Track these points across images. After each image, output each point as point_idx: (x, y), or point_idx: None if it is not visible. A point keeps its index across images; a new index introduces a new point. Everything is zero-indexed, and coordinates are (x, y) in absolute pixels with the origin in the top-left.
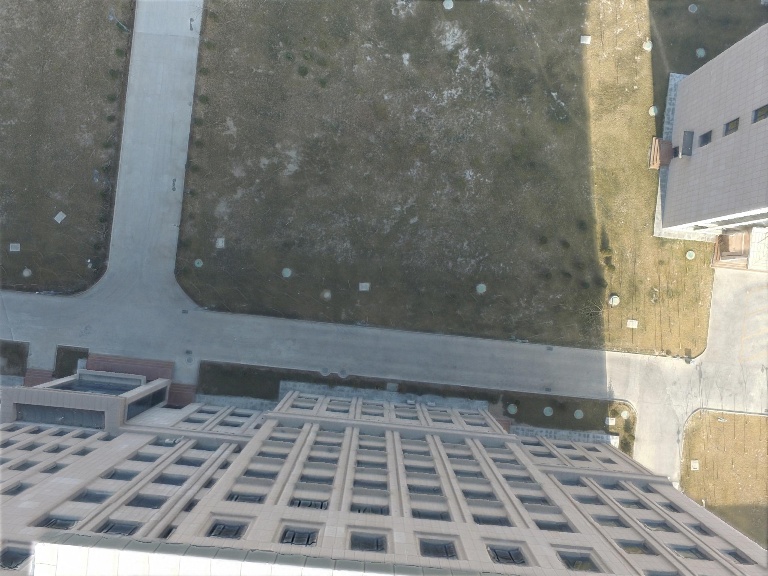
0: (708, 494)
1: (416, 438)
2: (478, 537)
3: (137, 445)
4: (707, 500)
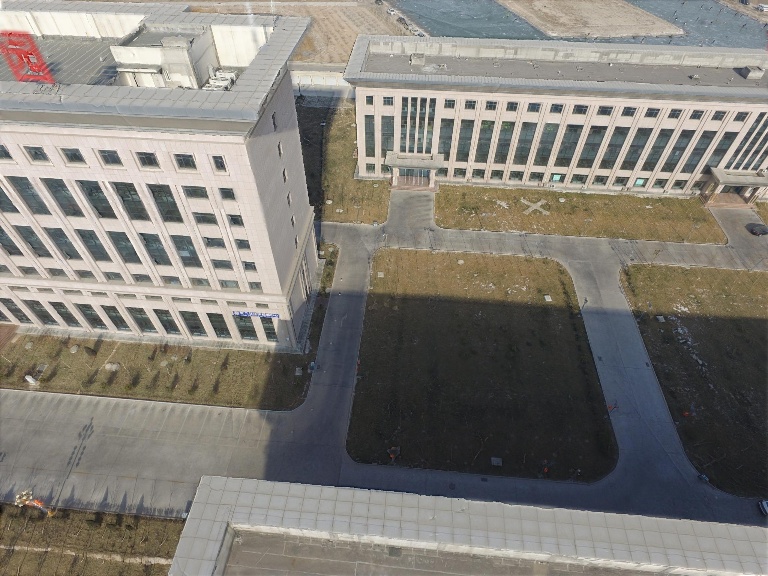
0: (392, 291)
1: None
2: None
3: None
4: (391, 294)
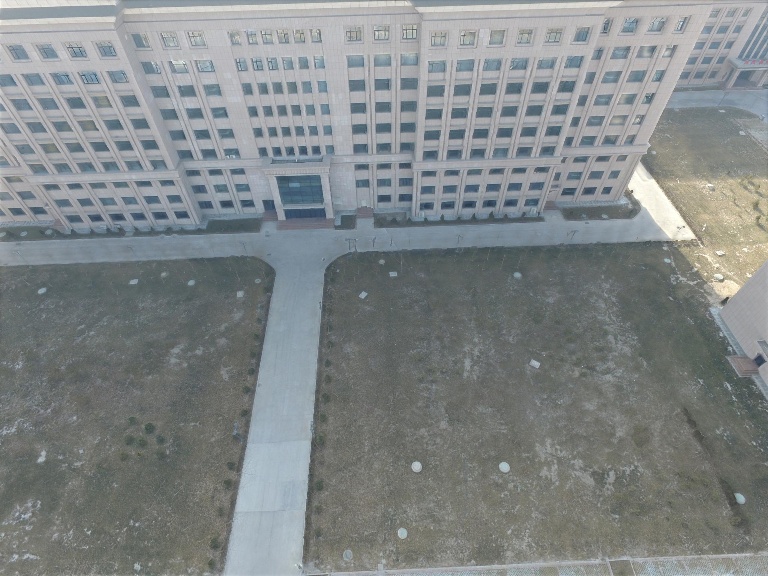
0: None
1: (88, 171)
2: (4, 62)
3: (240, 144)
4: None
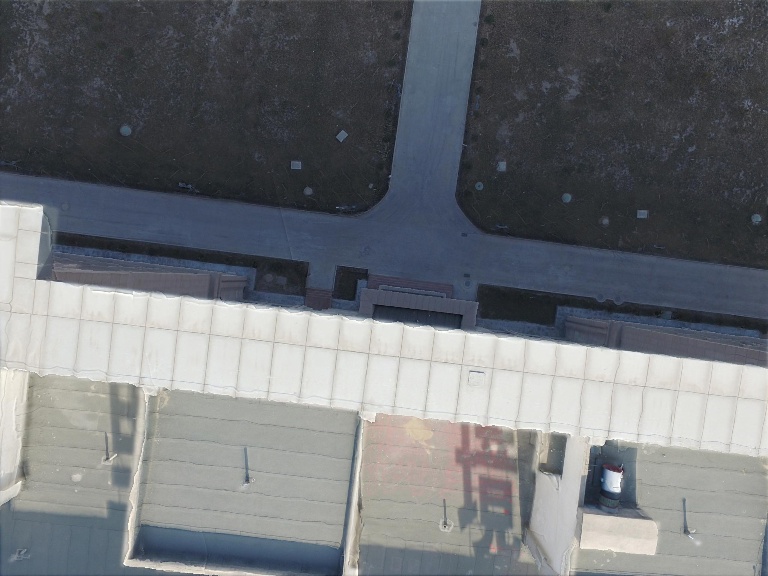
0: None
1: None
2: None
3: None
4: None
